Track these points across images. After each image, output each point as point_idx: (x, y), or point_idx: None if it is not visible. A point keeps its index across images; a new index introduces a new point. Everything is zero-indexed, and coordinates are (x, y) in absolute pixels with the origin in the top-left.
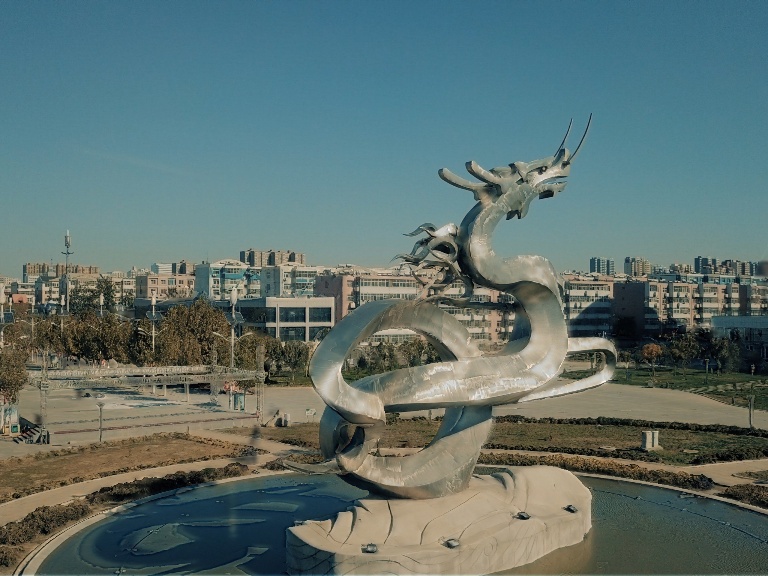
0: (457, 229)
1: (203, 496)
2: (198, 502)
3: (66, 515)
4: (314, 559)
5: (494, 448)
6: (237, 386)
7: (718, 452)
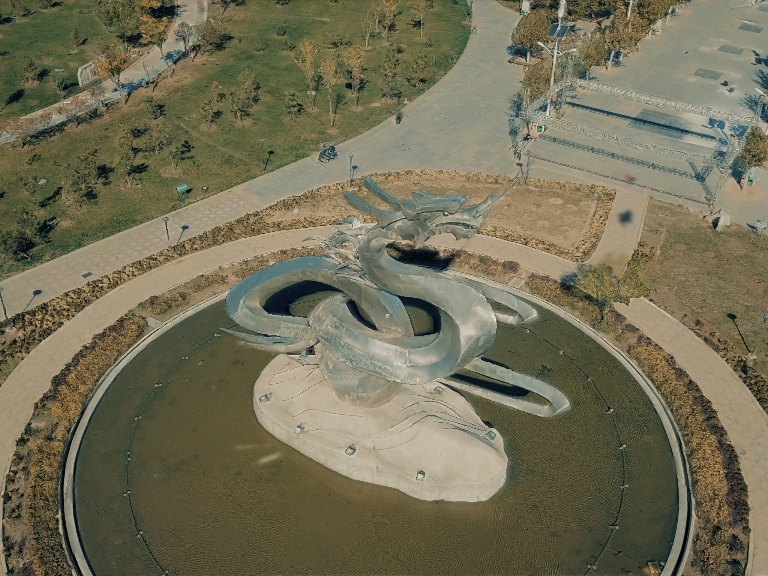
0: None
1: None
2: None
3: None
4: None
5: (747, 386)
6: None
7: None
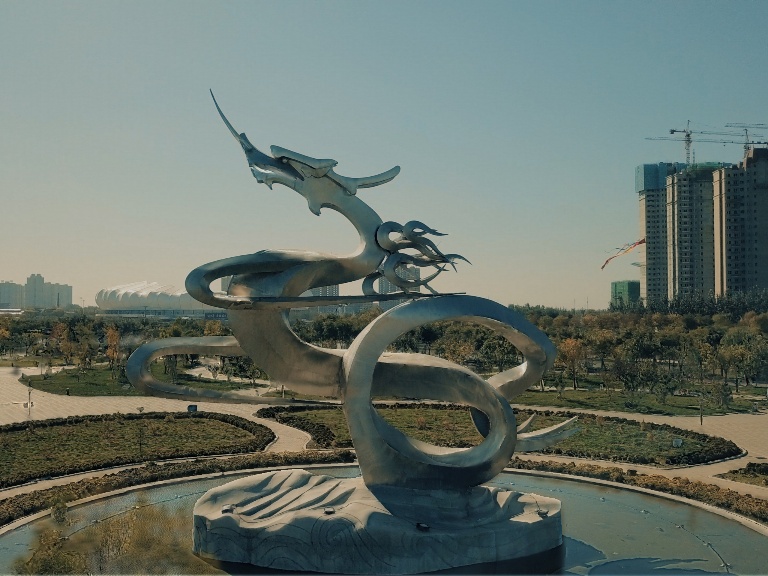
0: None
1: None
2: None
3: None
4: None
5: None
6: None
7: None
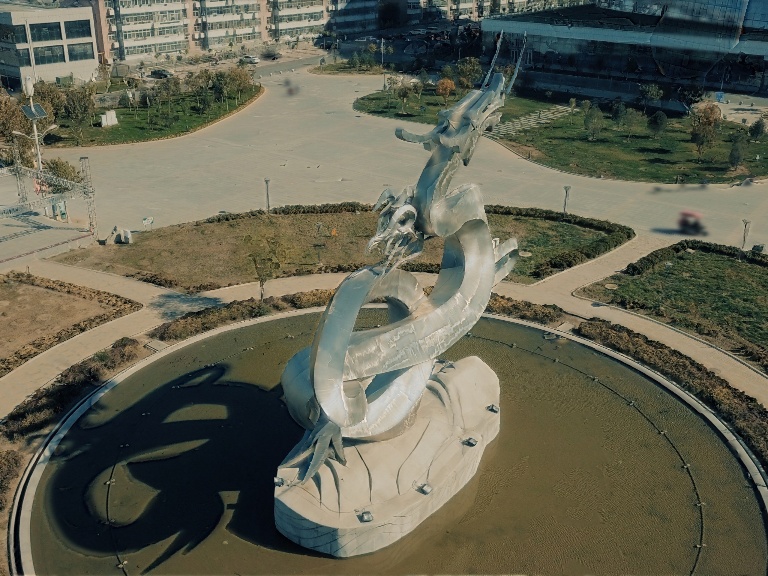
0: (414, 190)
1: (121, 404)
2: (121, 416)
3: (3, 474)
4: (315, 531)
5: None
6: (55, 193)
7: (548, 255)
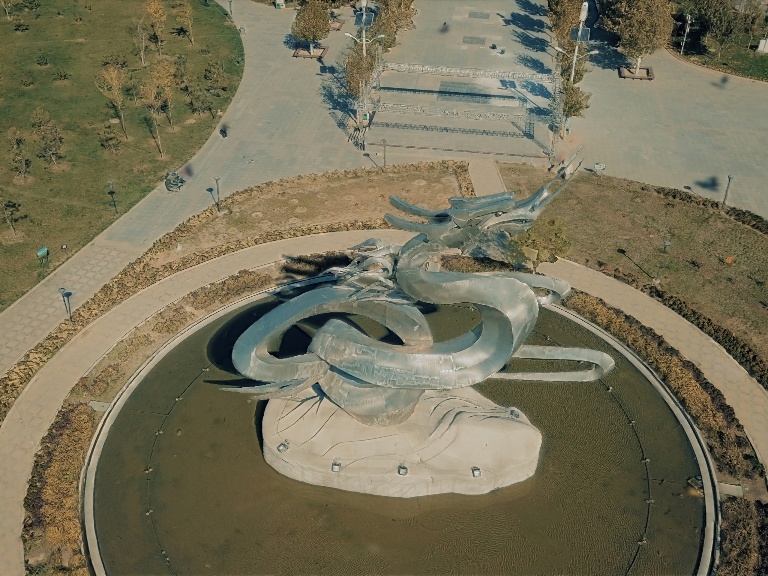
0: (400, 250)
1: None
2: None
3: (247, 286)
4: None
5: (669, 307)
6: None
7: None
